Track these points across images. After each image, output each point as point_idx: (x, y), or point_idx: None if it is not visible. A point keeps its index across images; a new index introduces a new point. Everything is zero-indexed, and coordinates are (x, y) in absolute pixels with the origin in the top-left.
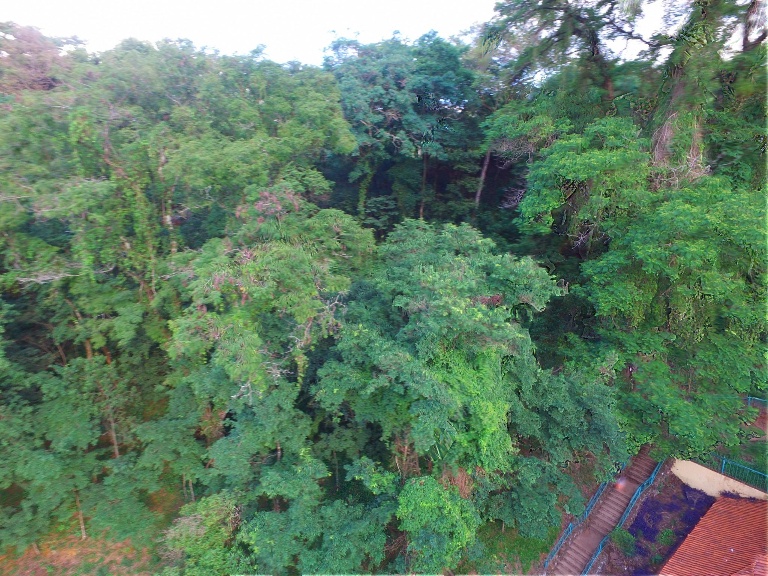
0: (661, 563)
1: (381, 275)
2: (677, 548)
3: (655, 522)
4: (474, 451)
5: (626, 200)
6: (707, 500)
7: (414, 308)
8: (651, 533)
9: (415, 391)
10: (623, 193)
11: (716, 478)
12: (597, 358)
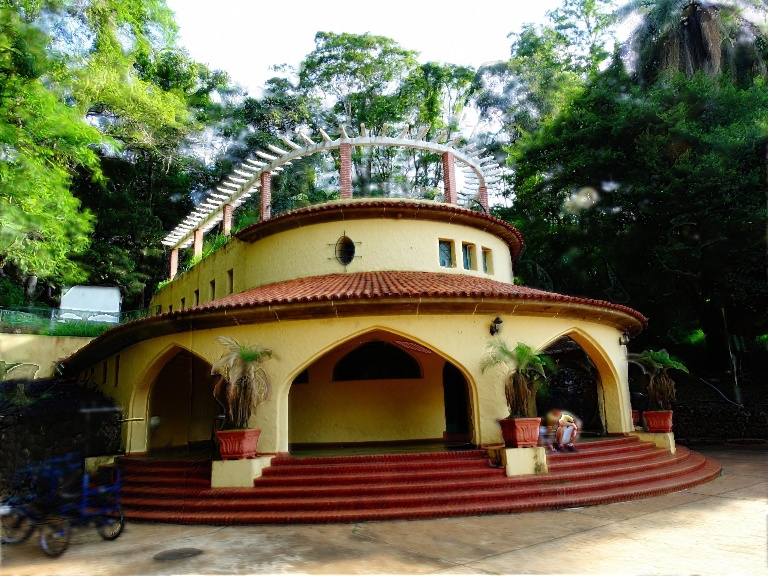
0: None
1: None
2: None
3: None
4: None
5: None
6: (39, 380)
7: None
8: None
9: None
10: None
11: (44, 344)
12: None
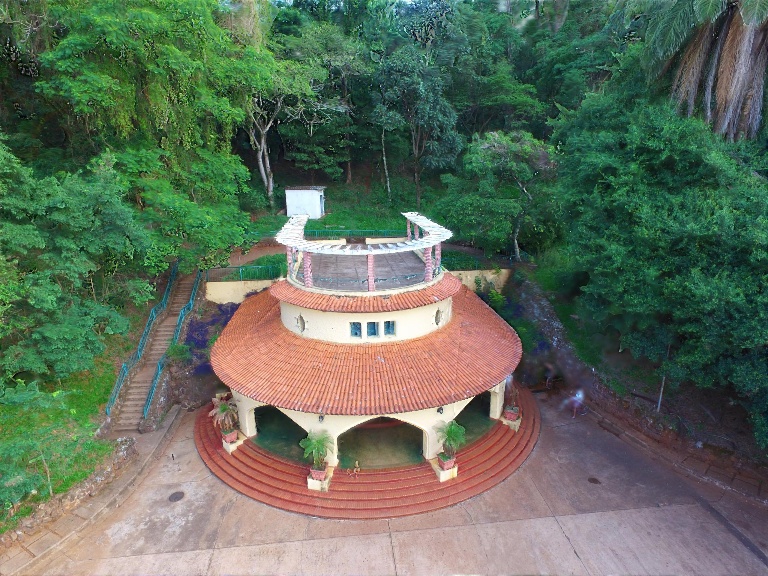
0: None
1: None
2: None
3: (203, 335)
4: None
5: None
6: (237, 306)
7: None
8: (202, 342)
9: None
10: None
11: (239, 286)
12: None
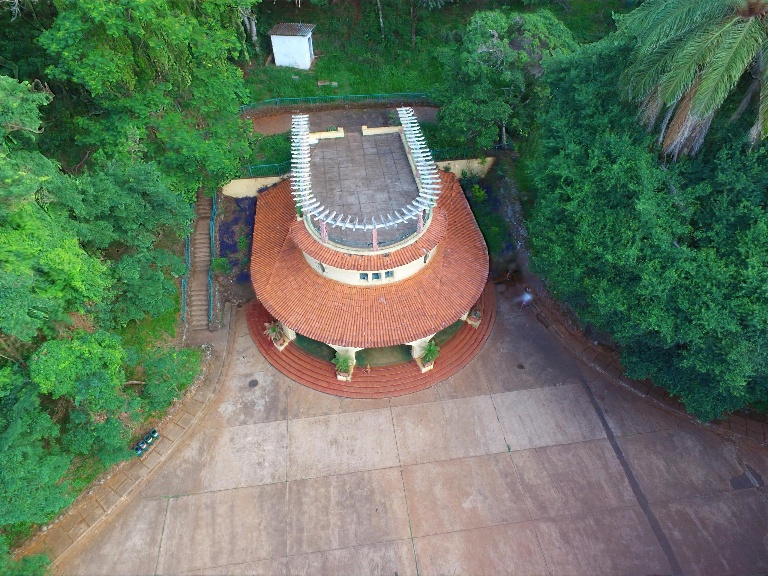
0: (248, 262)
1: None
2: None
3: (232, 238)
4: (73, 293)
5: None
6: (253, 201)
7: None
8: (233, 247)
9: None
10: None
11: (250, 183)
12: (121, 140)
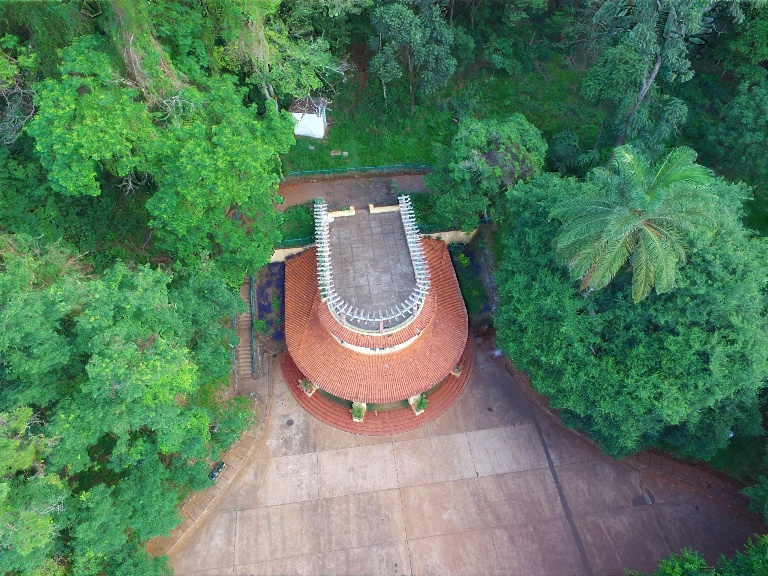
0: (281, 322)
1: (19, 358)
2: (283, 308)
3: (267, 299)
4: None
5: (151, 152)
6: (281, 266)
7: (113, 393)
8: (268, 308)
9: (148, 422)
10: (146, 149)
11: (280, 252)
12: None
